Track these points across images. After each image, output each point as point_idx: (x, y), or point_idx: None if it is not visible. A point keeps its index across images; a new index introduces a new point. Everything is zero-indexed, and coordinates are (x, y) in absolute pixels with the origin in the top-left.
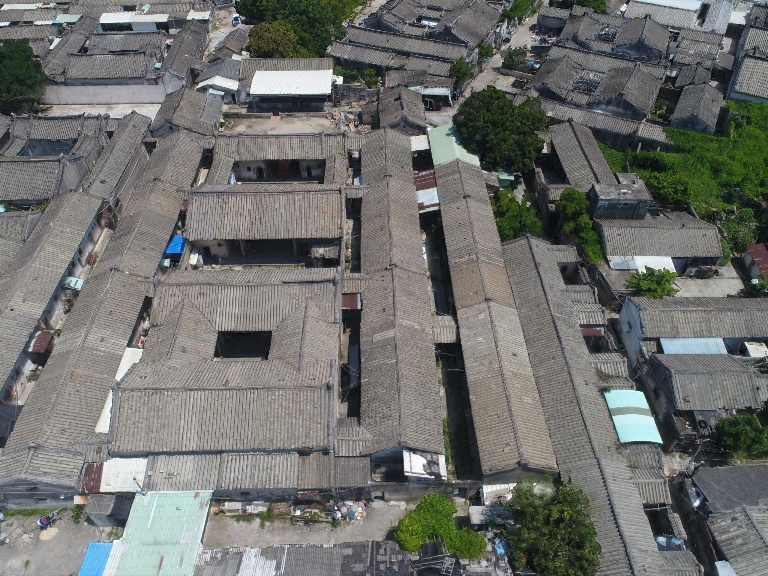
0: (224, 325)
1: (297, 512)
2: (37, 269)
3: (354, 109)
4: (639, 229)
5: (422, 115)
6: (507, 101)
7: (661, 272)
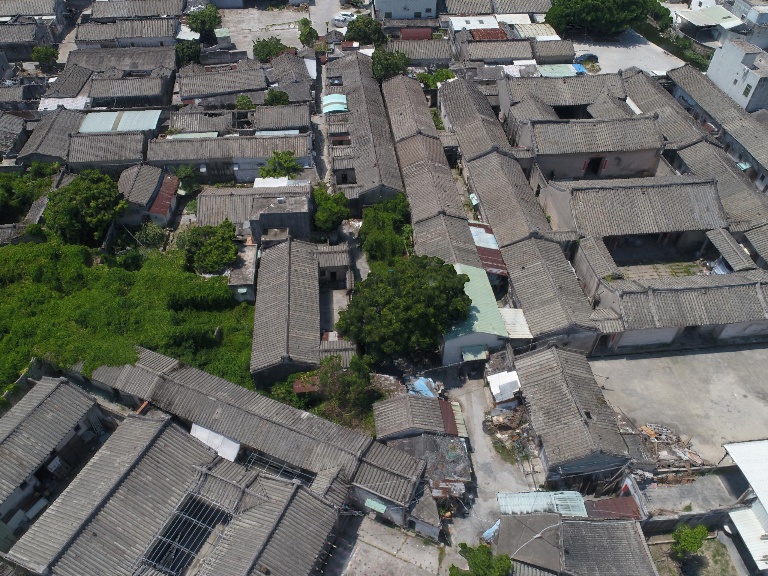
0: None
1: None
2: (764, 141)
3: (679, 505)
4: None
5: (530, 391)
6: (401, 276)
7: None
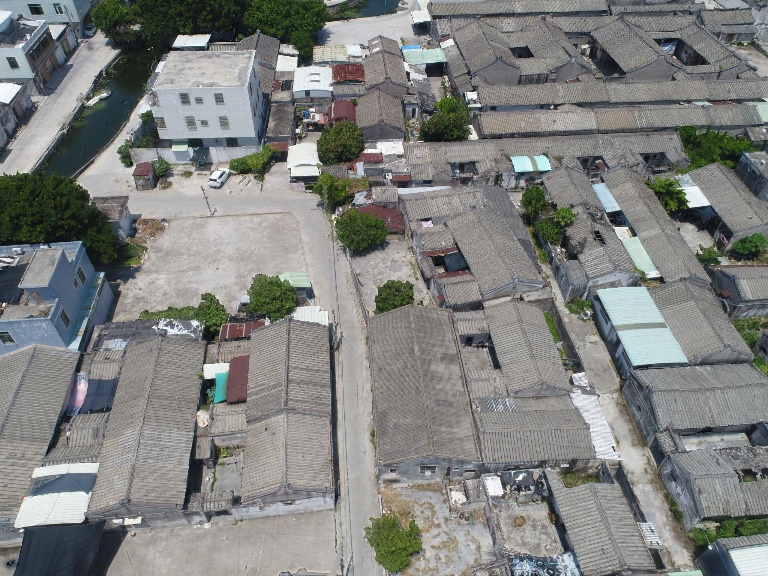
0: (531, 45)
1: (449, 94)
2: (542, 3)
3: None
4: (728, 182)
5: None
6: None
7: (674, 182)
